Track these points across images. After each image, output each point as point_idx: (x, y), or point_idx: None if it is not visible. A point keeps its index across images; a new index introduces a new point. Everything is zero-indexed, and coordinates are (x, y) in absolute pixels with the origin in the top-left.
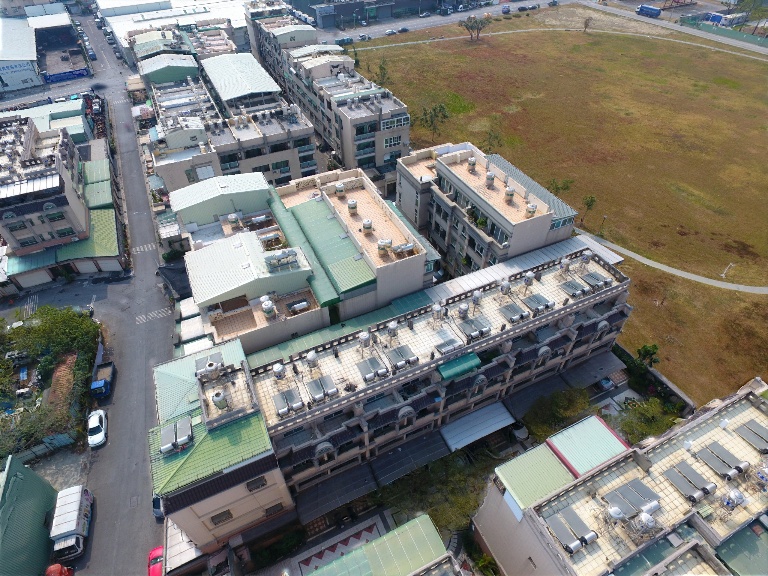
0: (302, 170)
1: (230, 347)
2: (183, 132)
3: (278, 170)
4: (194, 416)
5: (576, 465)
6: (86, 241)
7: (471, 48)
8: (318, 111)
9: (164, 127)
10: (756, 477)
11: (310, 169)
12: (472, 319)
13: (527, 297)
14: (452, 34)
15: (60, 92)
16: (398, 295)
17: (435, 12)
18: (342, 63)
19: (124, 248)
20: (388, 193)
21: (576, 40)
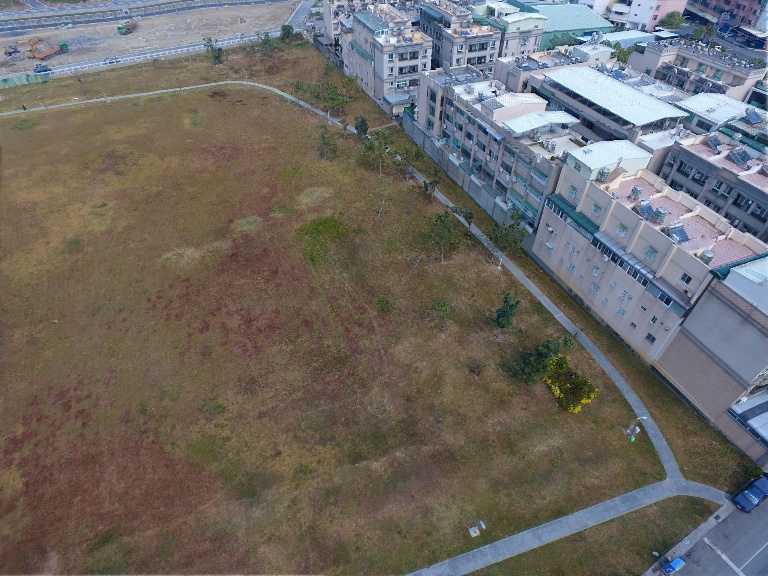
0: None
1: None
2: None
3: None
4: None
5: None
6: None
7: (120, 541)
8: None
9: None
10: None
11: None
12: None
13: None
14: None
15: None
16: None
17: None
18: None
19: None
20: None
21: None
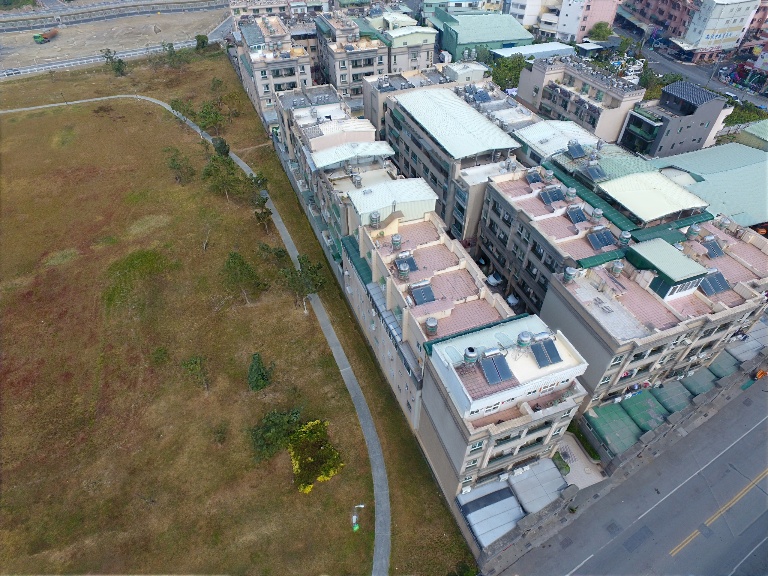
0: None
1: (391, 11)
2: None
3: None
4: None
5: None
6: None
7: None
8: None
9: None
10: None
11: None
12: None
13: None
14: None
15: None
16: None
17: None
18: None
19: None
20: None
21: None
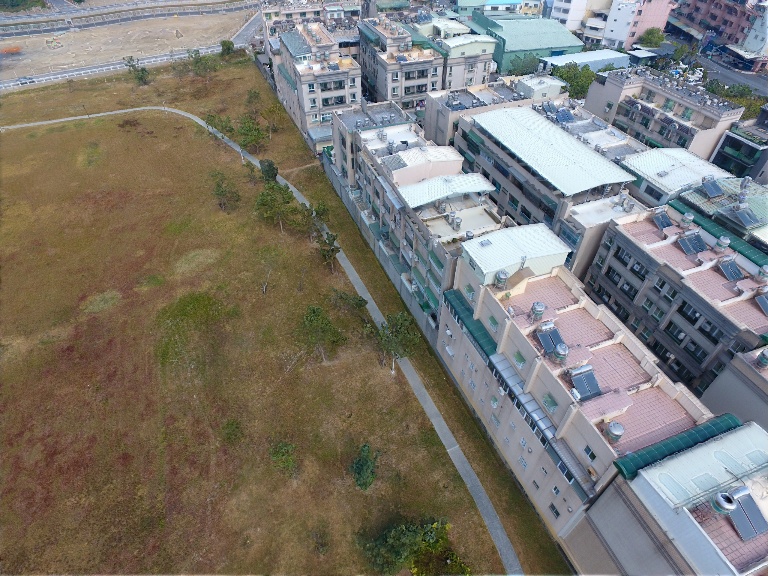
0: None
1: None
2: None
3: None
4: None
5: (340, 6)
6: None
7: None
8: None
9: None
10: None
11: None
12: None
13: None
14: None
15: None
16: None
17: None
18: None
19: None
20: None
21: None
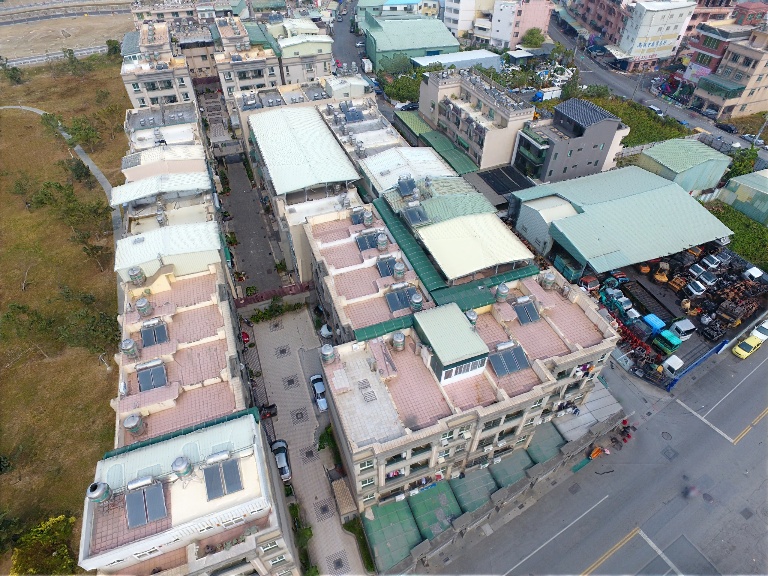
0: None
1: (299, 17)
2: None
3: None
4: (308, 9)
5: None
6: None
7: None
8: None
9: None
10: (172, 2)
11: None
12: None
13: None
14: None
15: None
16: None
17: None
18: None
19: (401, 131)
20: None
21: None
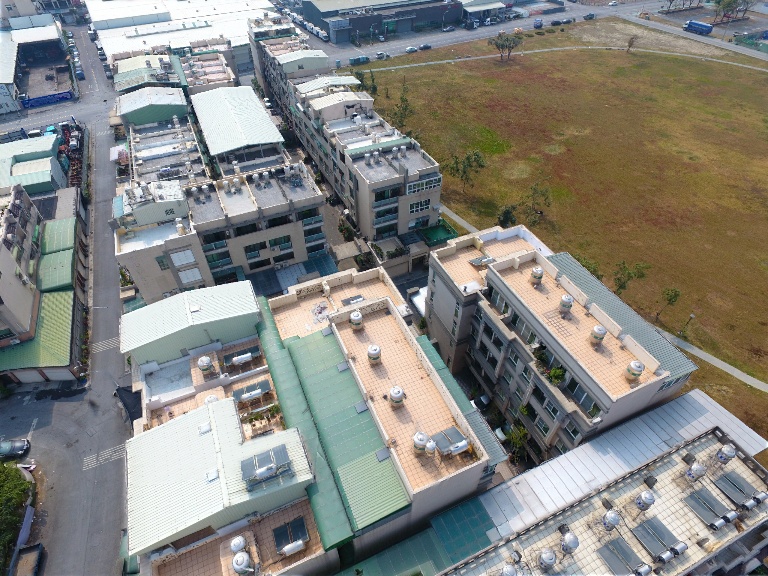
0: (307, 245)
1: None
2: (156, 205)
3: (277, 247)
4: None
5: None
6: (30, 343)
7: (502, 70)
8: (329, 159)
9: (131, 200)
10: None
11: (317, 243)
12: (560, 573)
13: (639, 524)
14: (480, 52)
15: (38, 120)
16: (441, 505)
17: (460, 26)
18: (359, 102)
19: (81, 346)
20: (412, 268)
21: (619, 61)
